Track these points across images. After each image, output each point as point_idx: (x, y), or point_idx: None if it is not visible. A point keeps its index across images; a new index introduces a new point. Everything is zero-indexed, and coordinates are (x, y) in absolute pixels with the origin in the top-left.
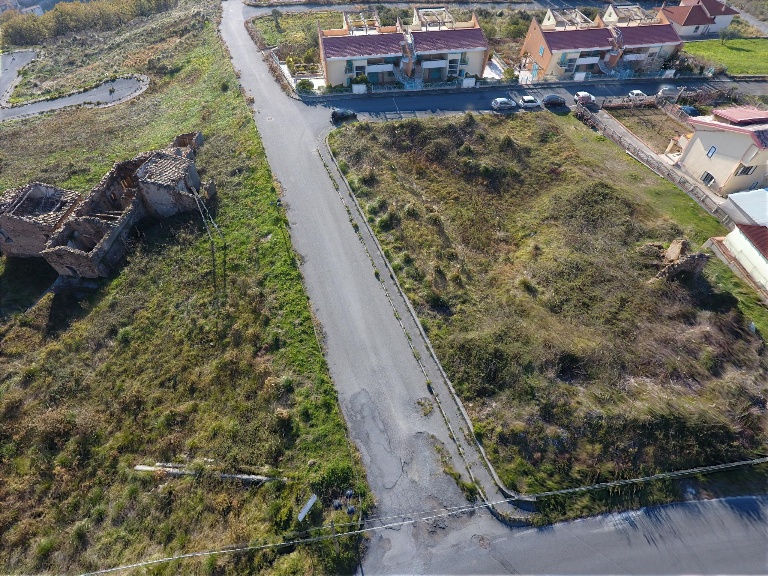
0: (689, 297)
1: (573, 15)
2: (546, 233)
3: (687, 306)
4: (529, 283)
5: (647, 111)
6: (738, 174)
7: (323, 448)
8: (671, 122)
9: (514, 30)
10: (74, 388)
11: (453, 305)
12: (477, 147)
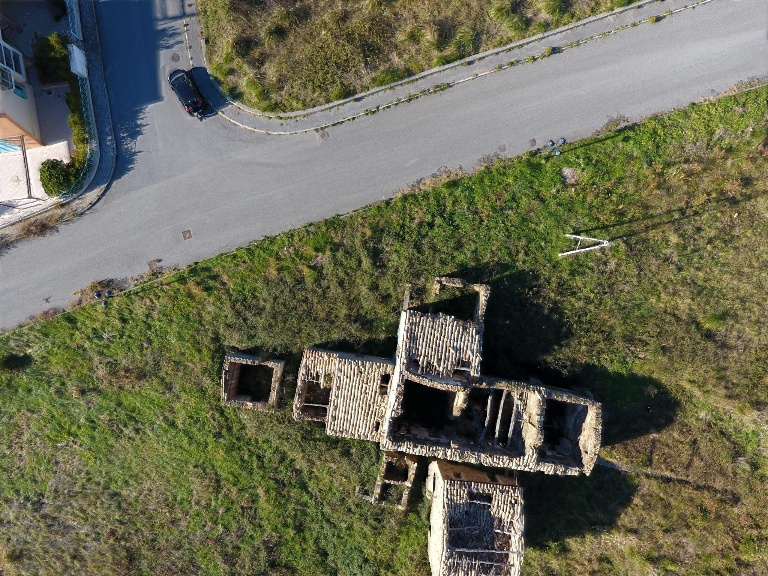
0: None
1: None
2: None
3: None
4: None
5: None
6: None
7: None
8: None
9: None
10: None
11: None
12: None
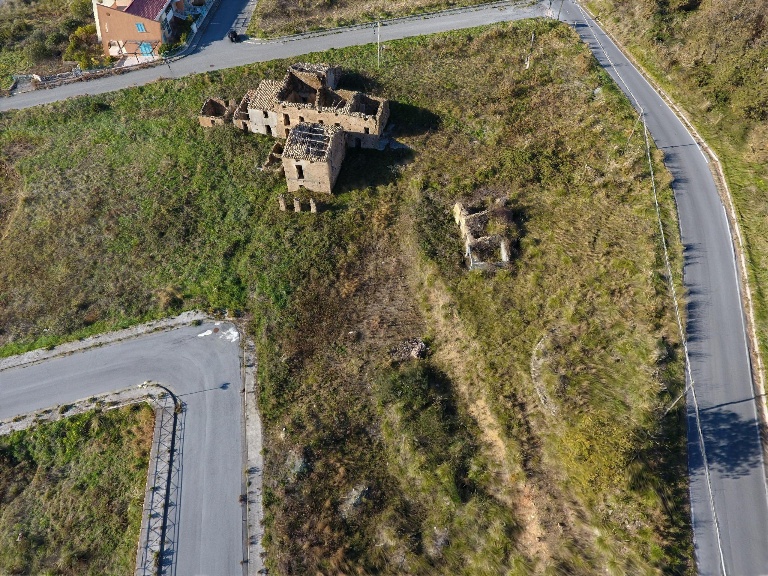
0: None
1: None
2: None
3: None
4: None
5: None
6: None
7: None
8: None
9: None
10: None
11: None
12: None
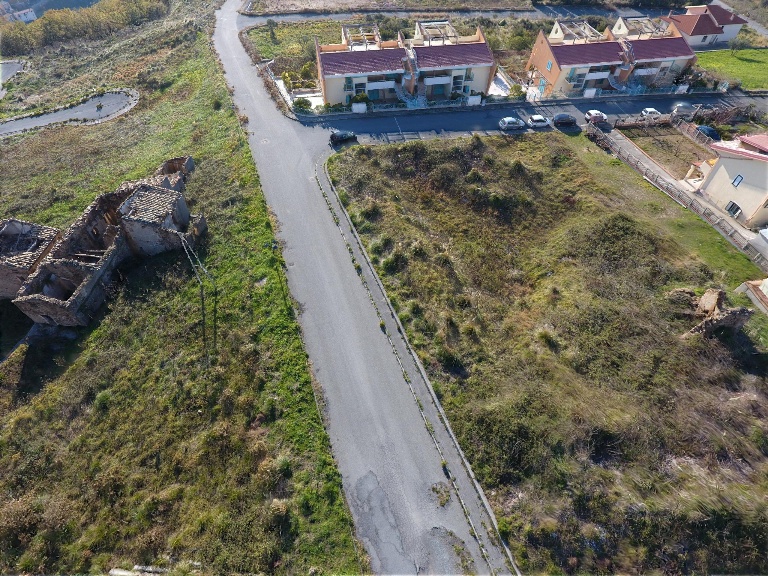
0: (731, 358)
1: (581, 27)
2: (564, 273)
3: (729, 368)
4: (550, 337)
5: (662, 131)
6: (767, 206)
7: (326, 551)
8: (688, 143)
9: (519, 42)
10: (44, 467)
11: (468, 364)
12: (486, 173)
